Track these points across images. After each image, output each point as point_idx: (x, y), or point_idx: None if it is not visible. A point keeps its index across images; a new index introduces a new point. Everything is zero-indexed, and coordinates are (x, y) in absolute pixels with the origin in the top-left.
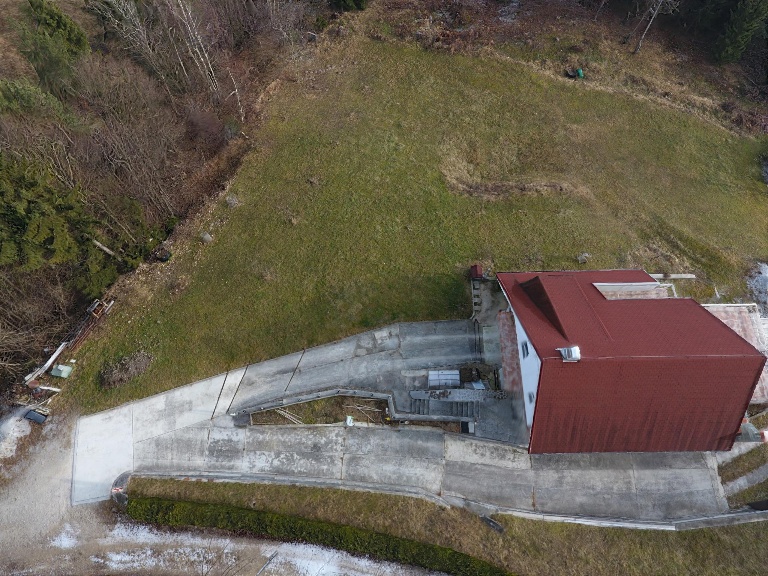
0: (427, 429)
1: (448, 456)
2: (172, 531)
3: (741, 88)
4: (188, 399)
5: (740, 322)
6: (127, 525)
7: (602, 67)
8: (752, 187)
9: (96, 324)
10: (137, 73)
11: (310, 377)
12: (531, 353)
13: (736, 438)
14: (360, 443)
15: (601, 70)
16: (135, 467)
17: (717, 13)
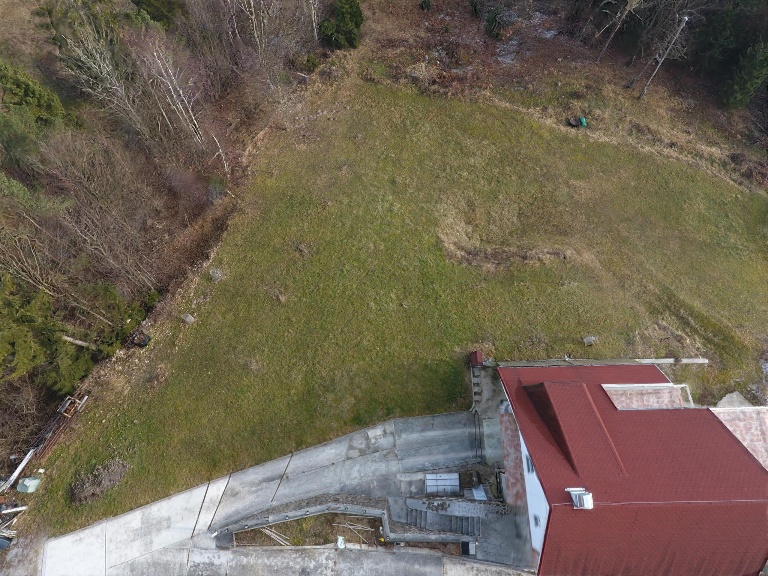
0: (424, 552)
1: None
2: None
3: (750, 135)
4: (166, 515)
5: (758, 424)
6: None
7: (606, 115)
8: (764, 249)
9: (68, 424)
10: (115, 132)
11: (298, 484)
12: None
13: None
14: (352, 567)
15: (605, 118)
16: None
17: (725, 55)
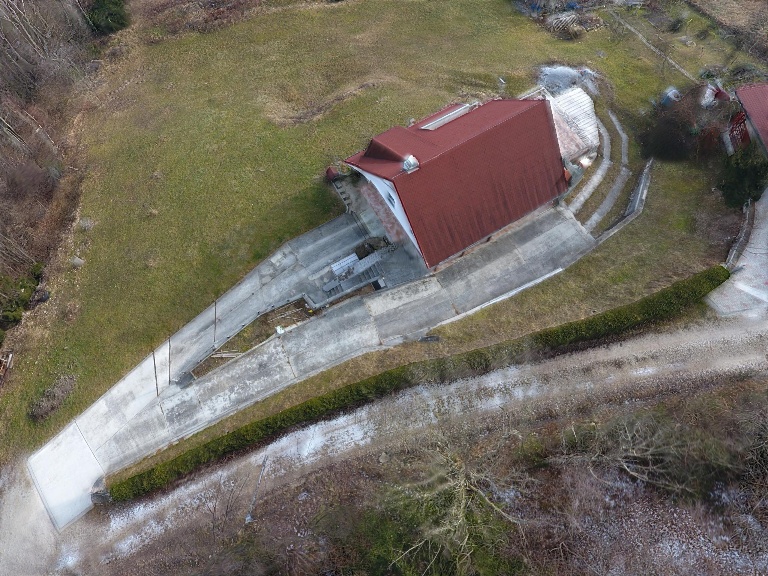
0: (346, 302)
1: (373, 313)
2: (166, 496)
3: None
4: (127, 392)
5: None
6: (121, 516)
7: None
8: (518, 23)
9: (3, 381)
10: None
11: (231, 320)
12: (393, 195)
13: (571, 183)
14: (297, 342)
15: None
16: (105, 471)
17: None
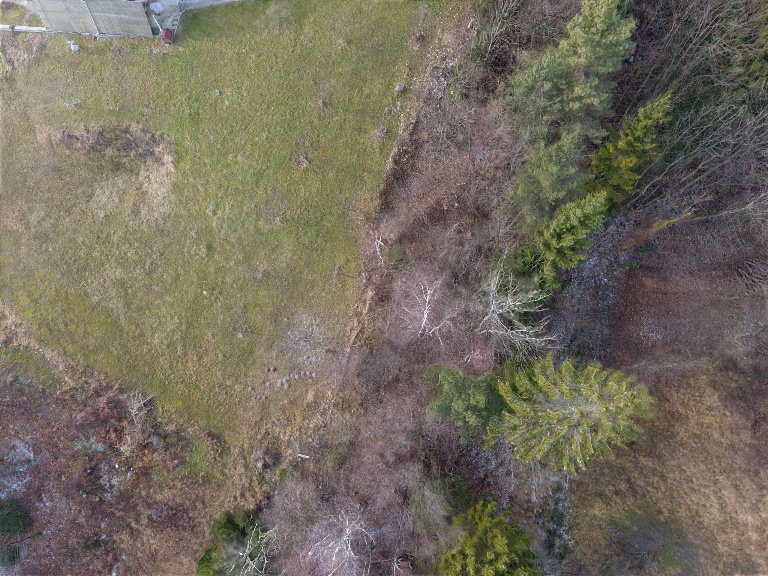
0: None
1: None
2: None
3: None
4: None
5: None
6: None
7: None
8: None
9: None
10: None
11: None
12: None
13: None
14: None
15: None
16: None
17: None
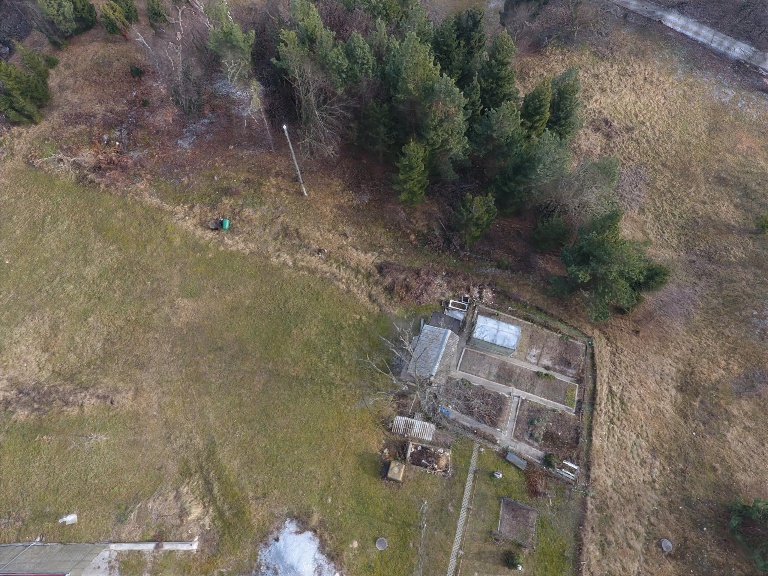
0: None
1: None
2: None
3: (426, 234)
4: None
5: None
6: None
7: (256, 215)
8: (366, 384)
9: None
10: None
11: None
12: None
13: None
14: None
15: (252, 220)
16: None
17: None
